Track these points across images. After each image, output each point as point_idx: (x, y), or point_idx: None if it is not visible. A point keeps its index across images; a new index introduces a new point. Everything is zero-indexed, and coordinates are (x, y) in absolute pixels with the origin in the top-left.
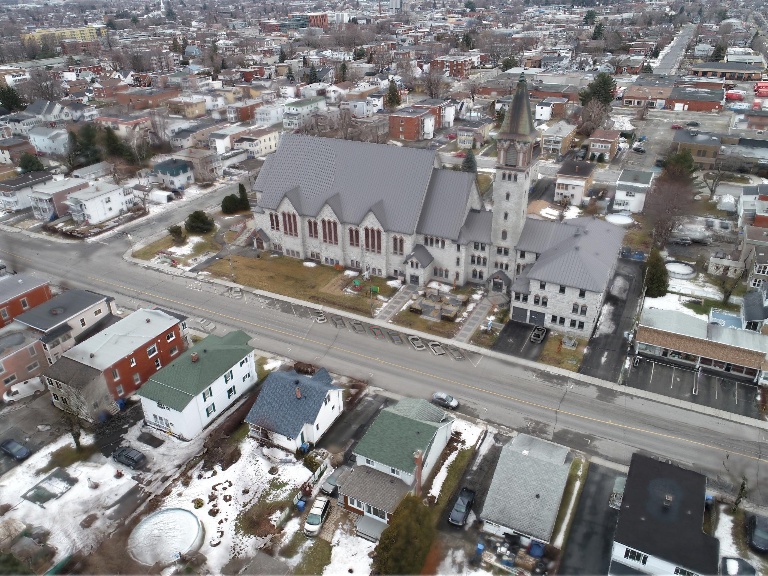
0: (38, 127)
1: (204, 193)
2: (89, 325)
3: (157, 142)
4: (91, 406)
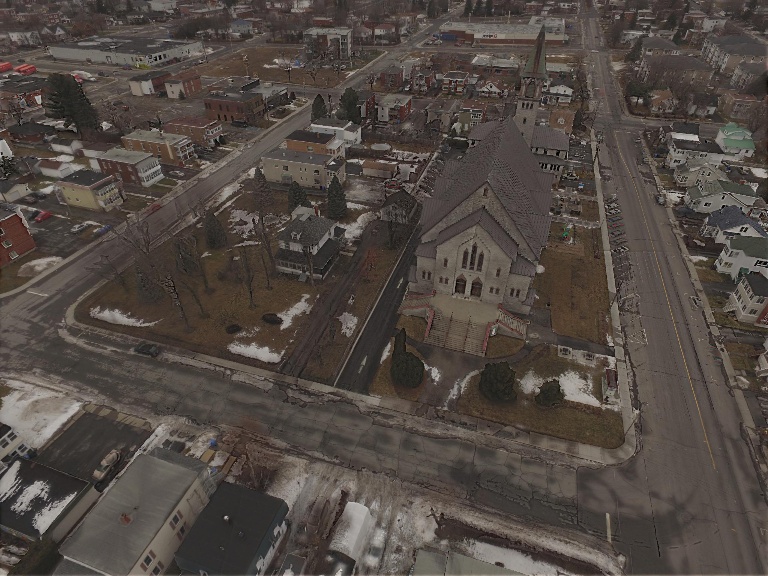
0: None
1: (307, 463)
2: None
3: None
4: None
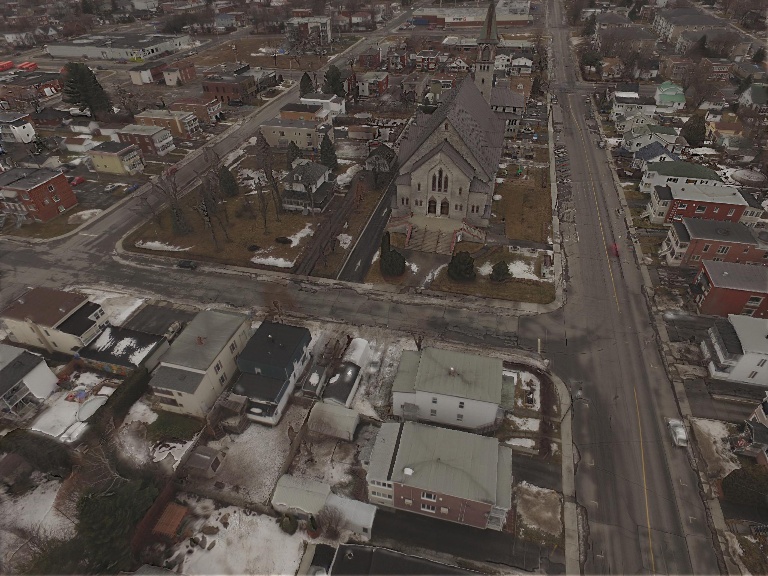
0: None
1: (321, 324)
2: None
3: None
4: None
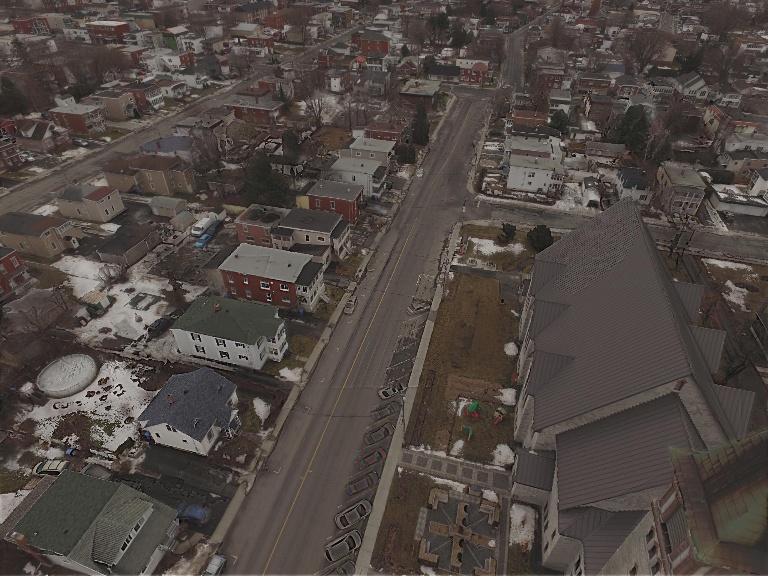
0: (641, 95)
1: None
2: (312, 243)
3: (709, 151)
4: (210, 283)
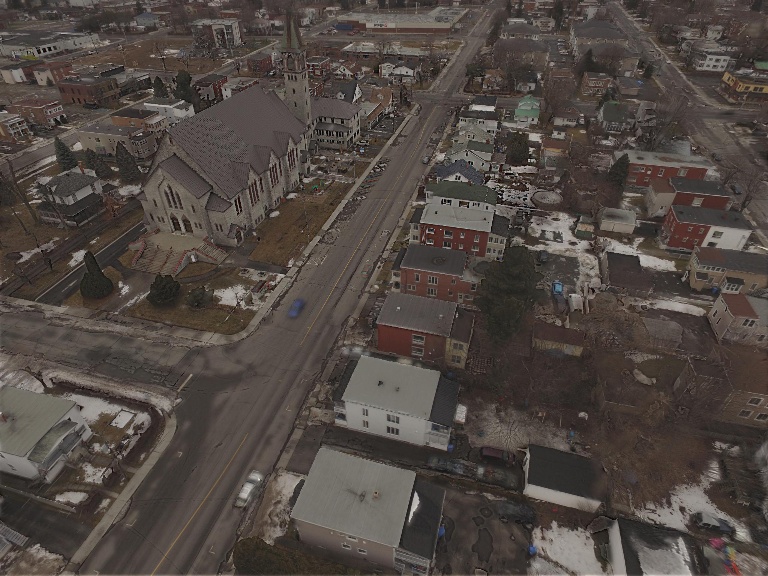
0: None
1: None
2: None
3: None
4: None
